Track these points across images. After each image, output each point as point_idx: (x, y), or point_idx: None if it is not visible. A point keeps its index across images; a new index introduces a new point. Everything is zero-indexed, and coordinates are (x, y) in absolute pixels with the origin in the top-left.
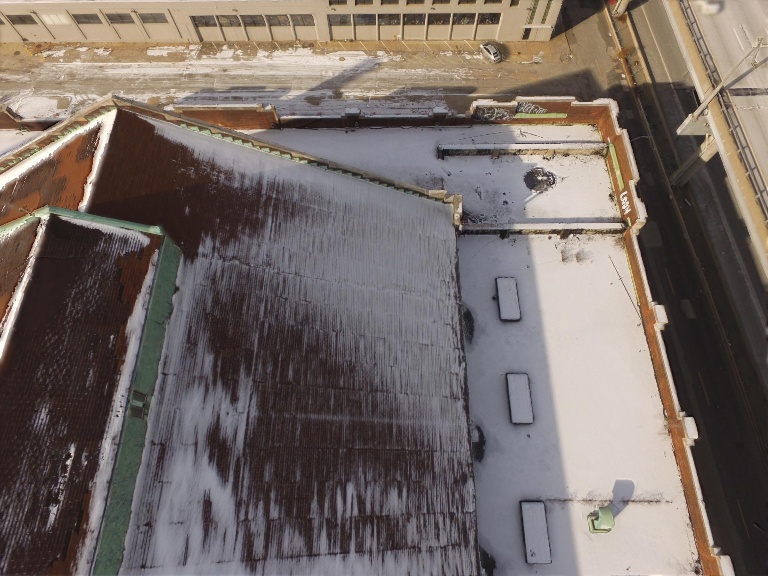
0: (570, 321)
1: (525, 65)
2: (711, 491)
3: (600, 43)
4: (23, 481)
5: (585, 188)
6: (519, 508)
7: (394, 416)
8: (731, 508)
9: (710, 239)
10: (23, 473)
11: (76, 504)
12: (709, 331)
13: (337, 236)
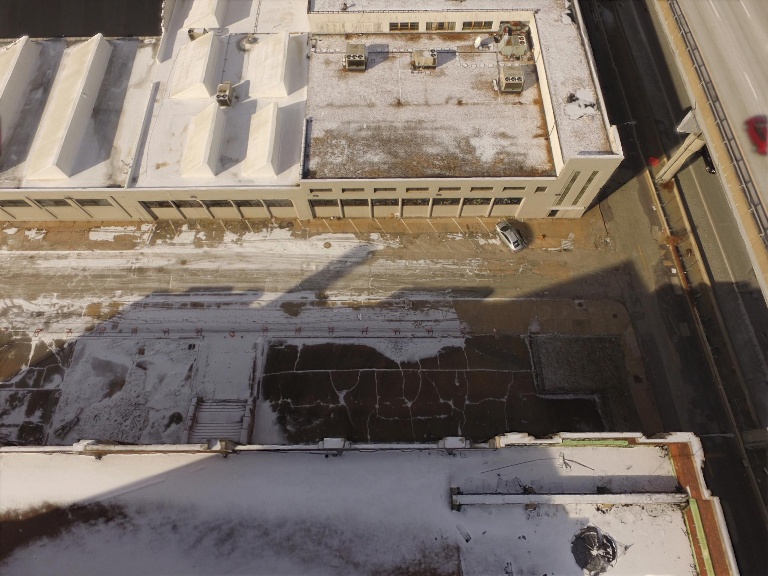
0: None
1: (552, 253)
2: None
3: (642, 220)
4: None
5: (658, 566)
6: None
7: None
8: None
9: None
10: None
11: None
12: None
13: None
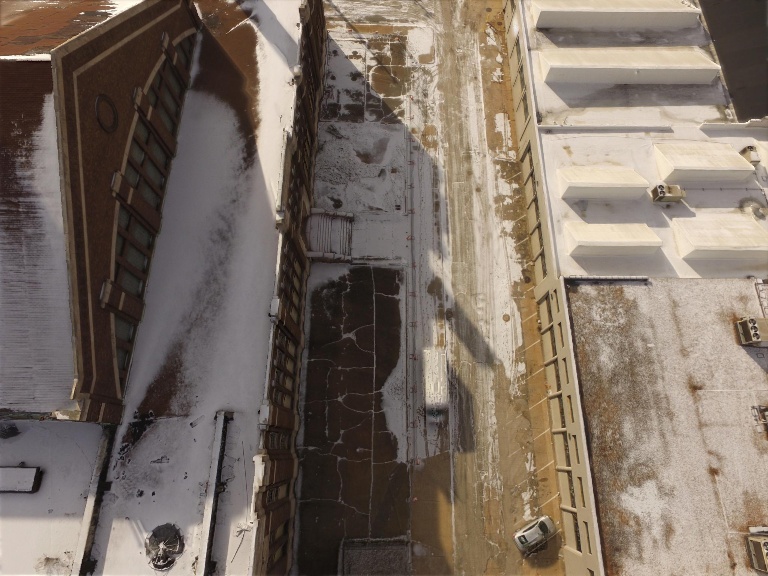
0: None
1: None
2: None
3: None
4: None
5: None
6: None
7: None
8: None
9: None
10: None
11: None
12: None
13: None
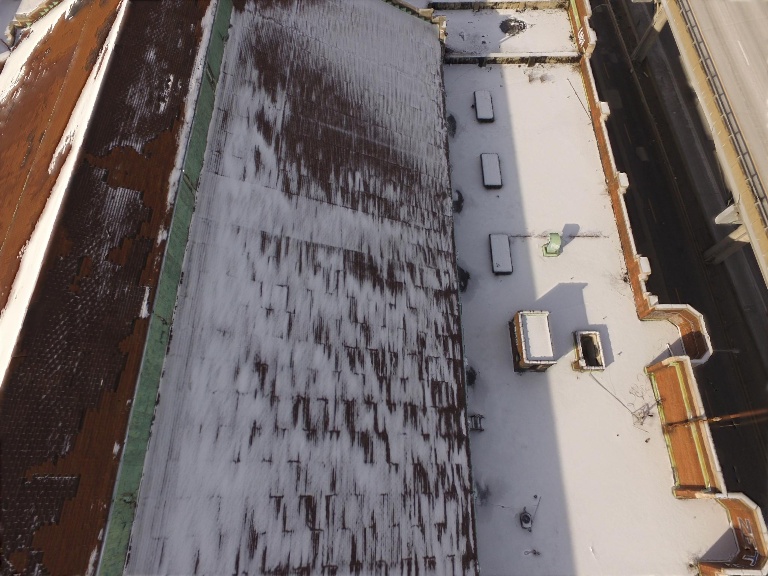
0: (534, 122)
1: None
2: (654, 282)
3: None
4: (143, 84)
5: (550, 32)
6: (489, 240)
7: (391, 144)
8: (670, 294)
9: (663, 102)
10: (142, 80)
11: (176, 106)
12: (659, 169)
13: (347, 24)
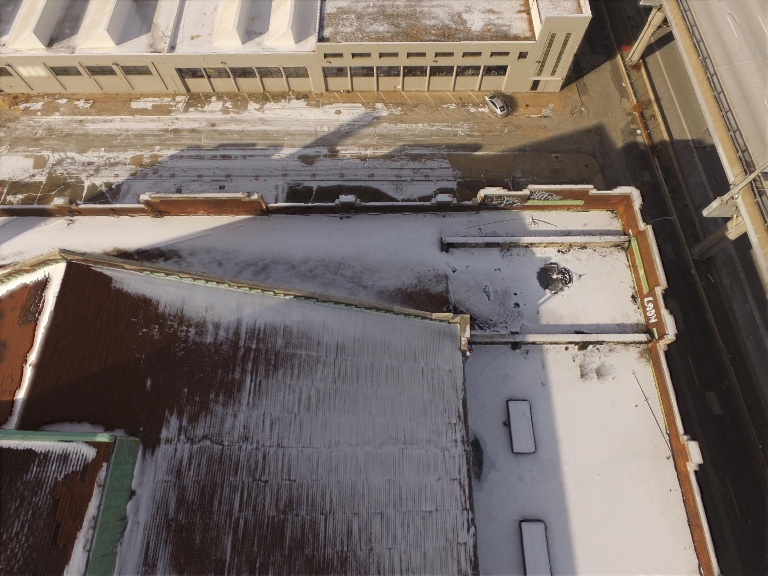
0: (591, 452)
1: (533, 119)
2: None
3: (613, 94)
4: None
5: (605, 287)
6: None
7: None
8: None
9: (736, 321)
10: None
11: None
12: (737, 430)
13: (327, 386)
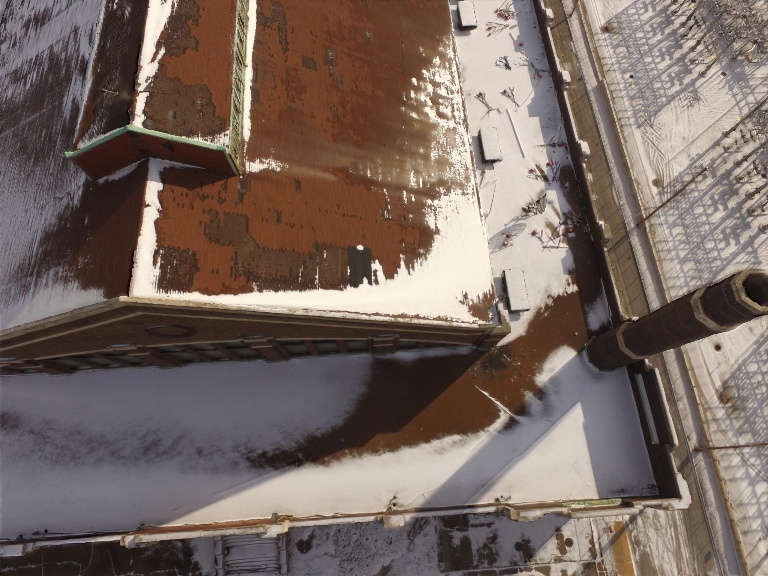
0: None
1: None
2: None
3: None
4: None
5: None
6: None
7: None
8: None
9: None
10: None
11: None
12: None
13: None
